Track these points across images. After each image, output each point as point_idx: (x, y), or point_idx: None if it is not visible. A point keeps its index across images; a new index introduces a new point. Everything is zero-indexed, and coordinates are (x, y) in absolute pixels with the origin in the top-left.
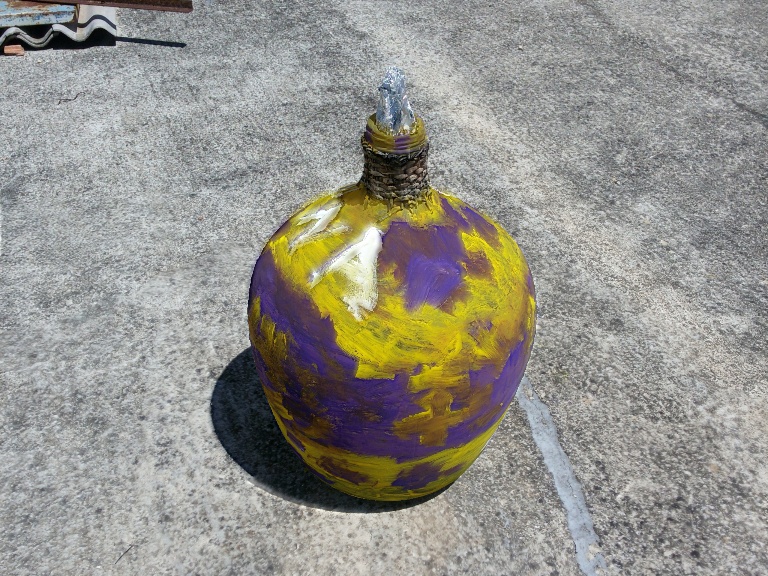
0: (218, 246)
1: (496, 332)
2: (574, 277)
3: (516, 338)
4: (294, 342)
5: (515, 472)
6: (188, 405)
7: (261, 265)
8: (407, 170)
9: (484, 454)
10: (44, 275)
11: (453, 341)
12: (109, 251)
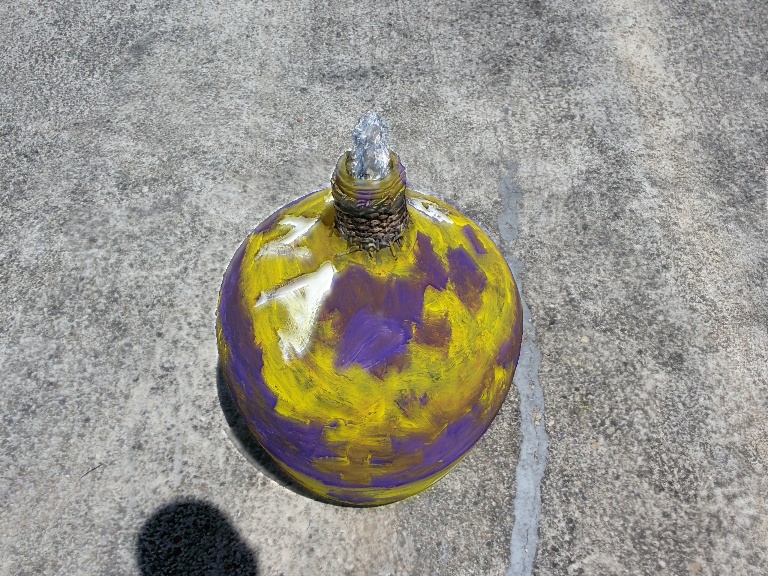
0: (303, 157)
1: (431, 403)
2: (657, 287)
3: (459, 409)
4: (231, 353)
5: (478, 503)
6: (204, 333)
7: (235, 255)
8: (367, 215)
9: (457, 473)
10: (135, 153)
11: (376, 405)
12: (201, 139)
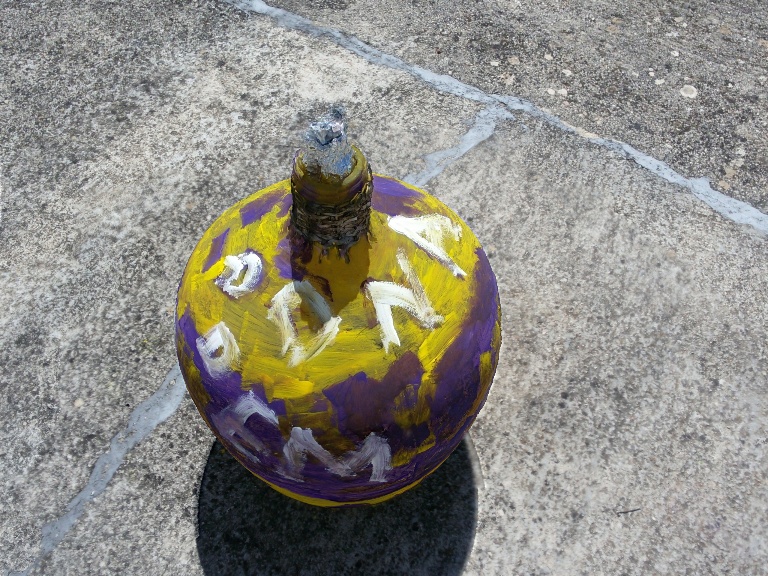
0: None
1: None
2: None
3: None
4: None
5: None
6: None
7: (453, 372)
8: None
9: None
10: None
11: None
12: None
